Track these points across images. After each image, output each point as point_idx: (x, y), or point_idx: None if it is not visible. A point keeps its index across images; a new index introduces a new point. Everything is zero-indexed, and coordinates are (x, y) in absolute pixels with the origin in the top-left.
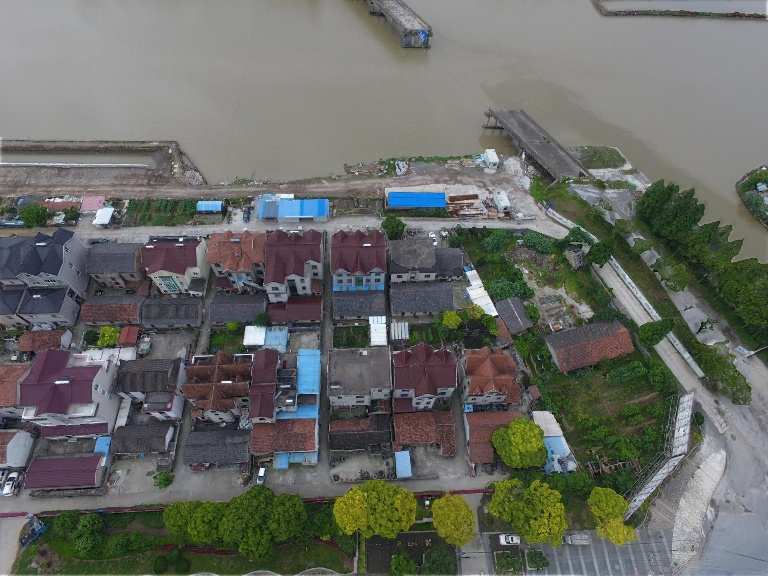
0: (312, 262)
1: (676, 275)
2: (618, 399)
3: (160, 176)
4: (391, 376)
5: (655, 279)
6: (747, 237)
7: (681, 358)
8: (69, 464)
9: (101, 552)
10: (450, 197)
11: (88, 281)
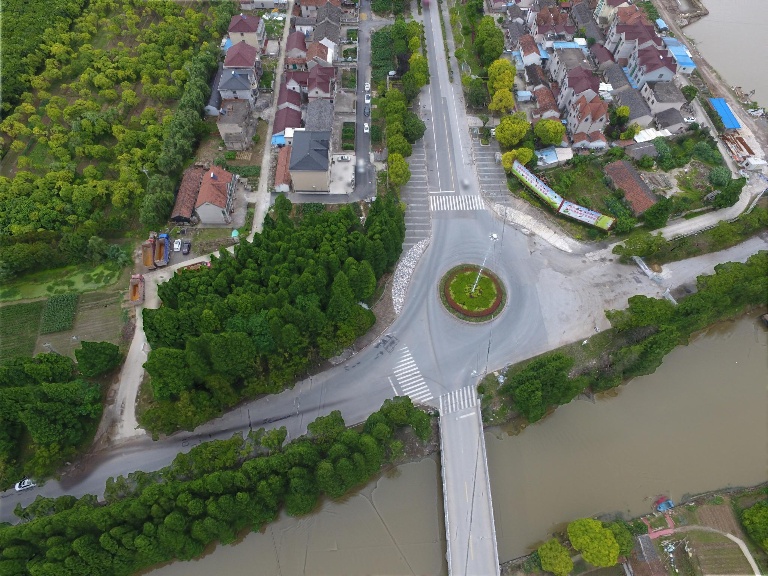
0: (637, 42)
1: (725, 228)
2: (594, 202)
3: (675, 10)
4: None
5: None
6: None
7: None
8: None
9: None
10: (741, 137)
11: None
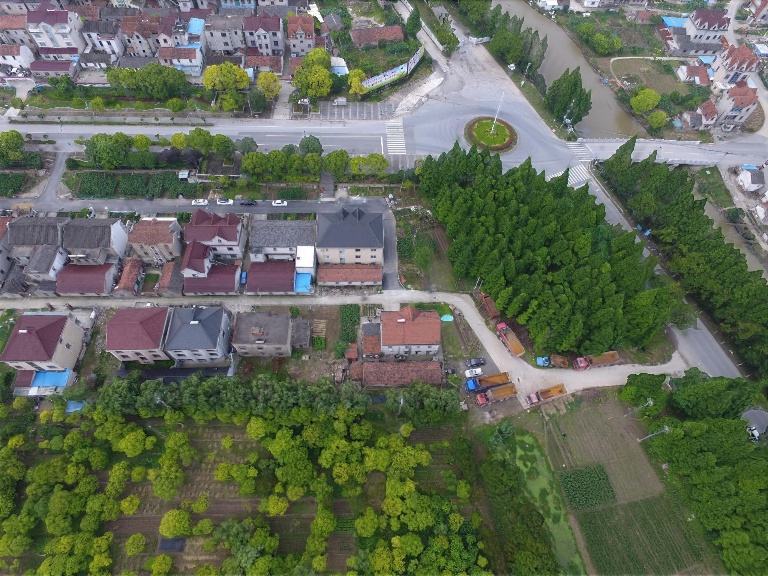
0: None
1: None
2: None
3: None
4: (242, 24)
5: (430, 11)
6: (511, 6)
7: (434, 44)
8: (55, 62)
9: (72, 96)
10: None
11: (68, 3)
